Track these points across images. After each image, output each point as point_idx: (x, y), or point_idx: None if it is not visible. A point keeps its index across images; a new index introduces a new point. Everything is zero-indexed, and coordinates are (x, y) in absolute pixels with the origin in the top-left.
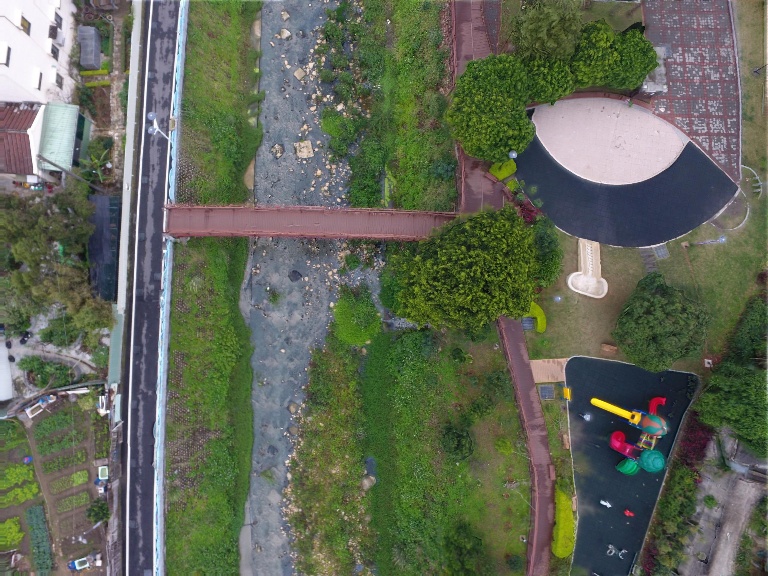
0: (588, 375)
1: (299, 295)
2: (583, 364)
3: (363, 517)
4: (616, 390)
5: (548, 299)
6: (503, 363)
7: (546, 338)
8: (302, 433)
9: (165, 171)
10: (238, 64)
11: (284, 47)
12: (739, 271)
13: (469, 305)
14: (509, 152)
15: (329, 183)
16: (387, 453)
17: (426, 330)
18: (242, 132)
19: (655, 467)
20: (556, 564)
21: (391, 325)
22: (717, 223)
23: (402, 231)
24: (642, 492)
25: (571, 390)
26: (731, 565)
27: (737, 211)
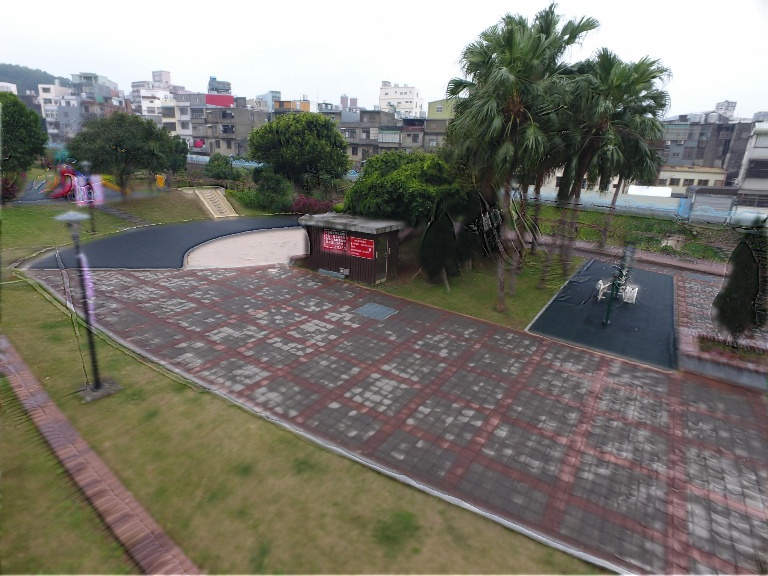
0: None
1: None
2: None
3: None
4: None
5: None
6: None
7: None
8: None
9: None
10: None
11: None
12: None
13: None
14: None
15: None
16: None
17: None
18: None
19: None
20: None
21: None
22: None
23: None
24: None
25: None
26: None
27: None
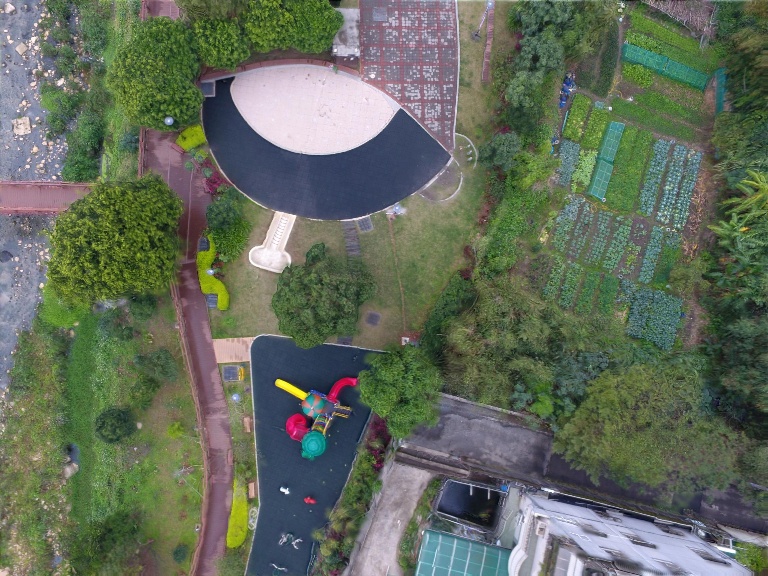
0: (275, 355)
1: (9, 276)
2: (270, 343)
3: (64, 506)
4: (304, 370)
5: (233, 275)
6: (174, 342)
7: (231, 316)
8: (5, 419)
9: None
10: None
11: (8, 22)
12: (445, 244)
13: (83, 277)
14: (165, 119)
15: (45, 160)
16: (89, 439)
17: (116, 309)
18: None
19: (309, 450)
20: (230, 554)
21: (101, 306)
22: (427, 194)
23: None
24: (328, 478)
25: (256, 370)
26: (399, 555)
27: (449, 181)
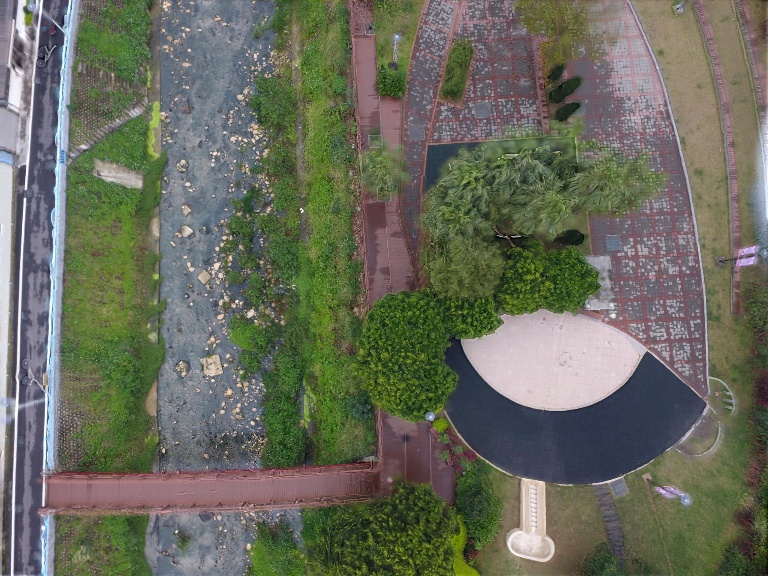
0: None
1: (212, 536)
2: None
3: None
4: None
5: (486, 559)
6: None
7: None
8: None
9: (43, 429)
10: (133, 274)
11: (186, 246)
12: (711, 508)
13: None
14: (425, 414)
15: (241, 404)
16: None
17: None
18: (141, 351)
19: None
20: None
21: (316, 568)
22: (683, 448)
23: (312, 491)
24: None
25: None
26: None
27: (706, 432)
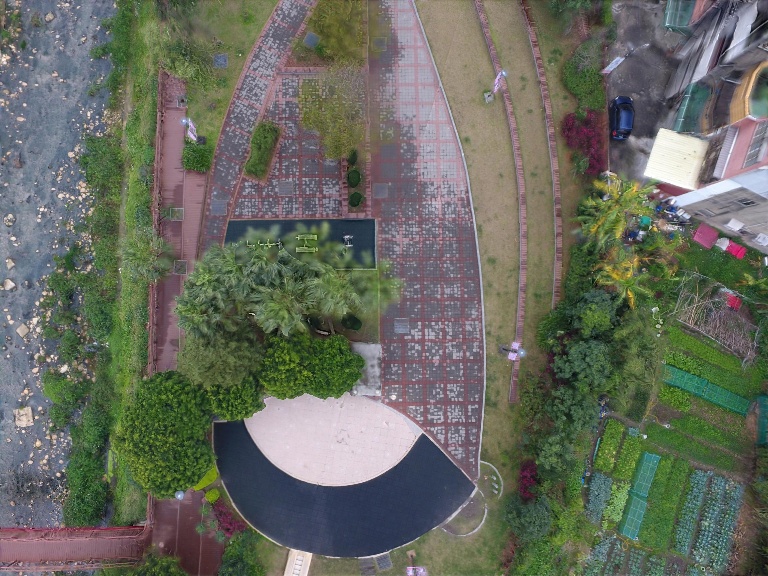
0: None
1: None
2: None
3: None
4: None
5: None
6: None
7: None
8: None
9: None
10: None
11: (8, 299)
12: None
13: None
14: (175, 492)
15: (49, 456)
16: None
17: None
18: None
19: None
20: None
21: None
22: (450, 527)
23: (82, 553)
24: None
25: None
26: None
27: (473, 513)
